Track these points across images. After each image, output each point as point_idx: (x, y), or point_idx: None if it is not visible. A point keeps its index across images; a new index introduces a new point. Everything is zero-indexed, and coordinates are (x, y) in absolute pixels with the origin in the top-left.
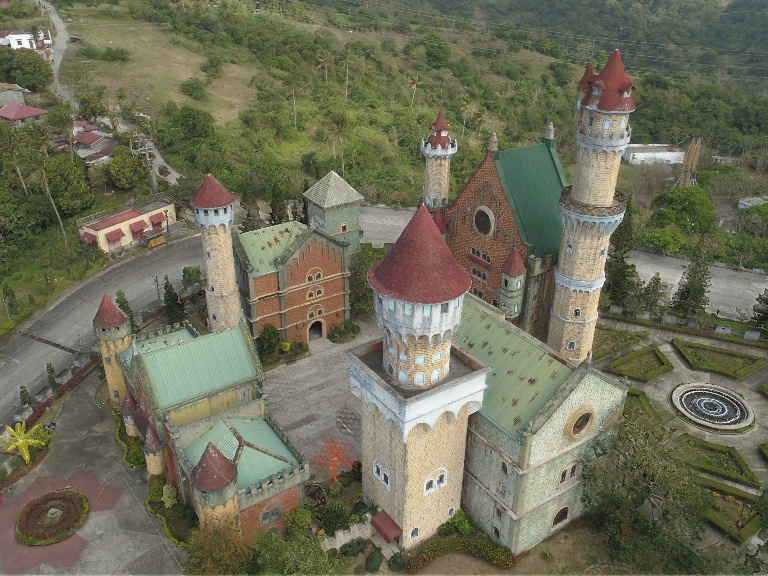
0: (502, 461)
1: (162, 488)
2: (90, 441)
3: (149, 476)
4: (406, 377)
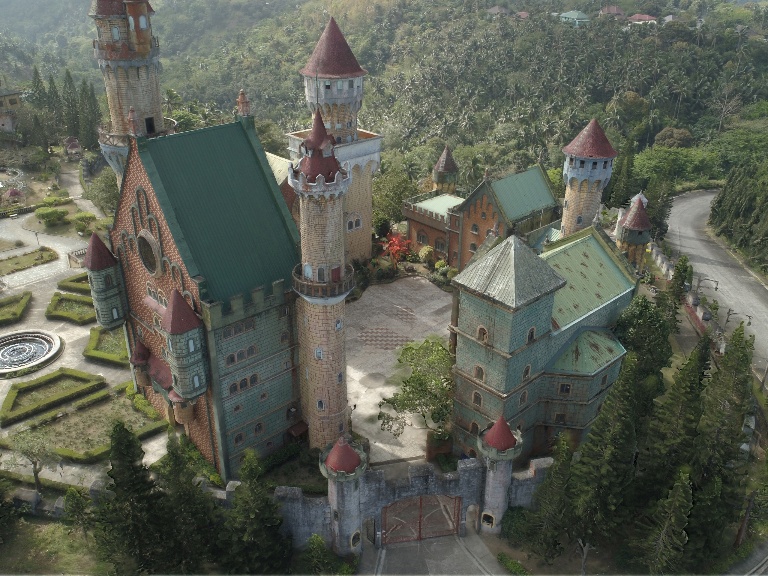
0: None
1: None
2: None
3: None
4: None
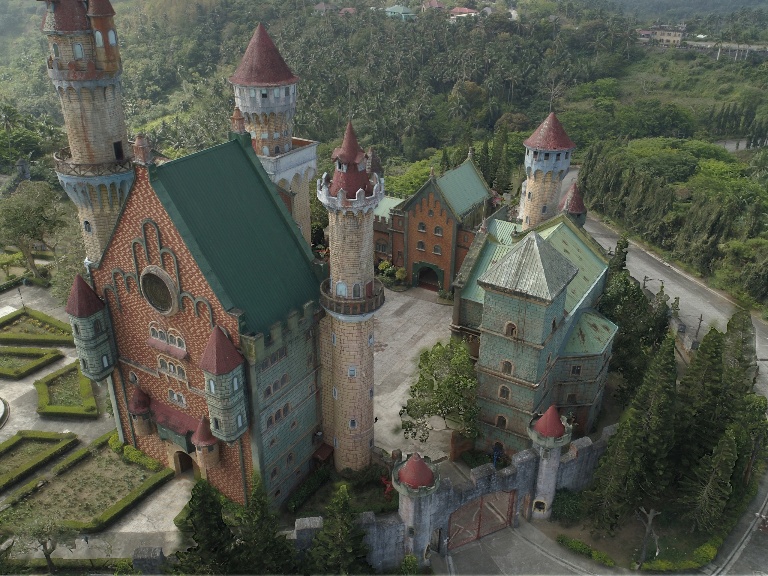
0: None
1: None
2: None
3: None
4: None
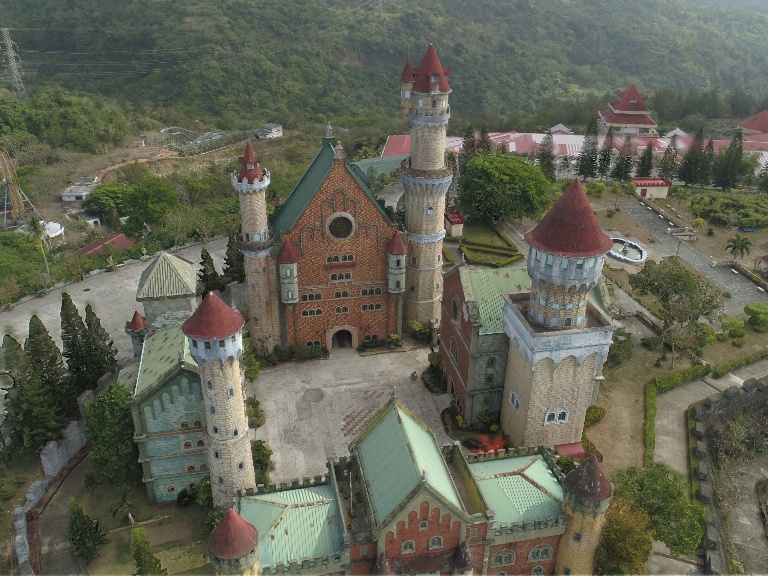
0: None
1: None
2: None
3: None
4: None
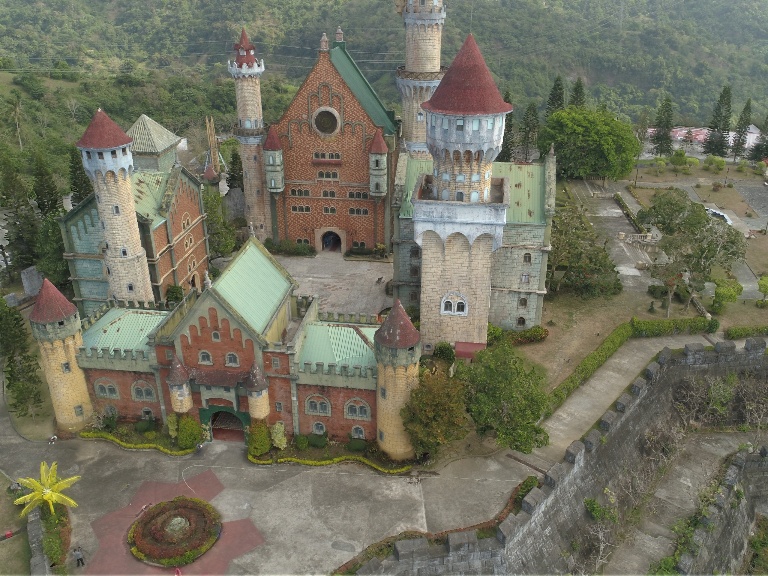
0: (525, 253)
1: (269, 433)
2: (97, 468)
3: (217, 449)
4: (478, 196)
